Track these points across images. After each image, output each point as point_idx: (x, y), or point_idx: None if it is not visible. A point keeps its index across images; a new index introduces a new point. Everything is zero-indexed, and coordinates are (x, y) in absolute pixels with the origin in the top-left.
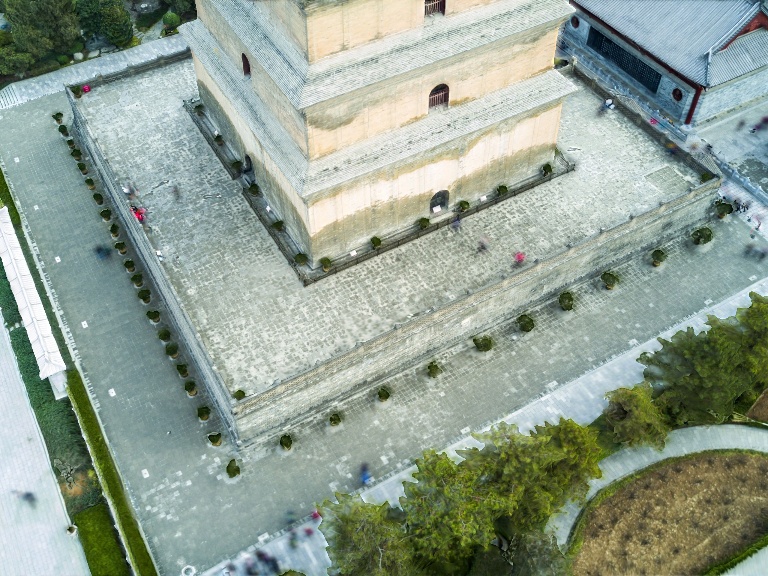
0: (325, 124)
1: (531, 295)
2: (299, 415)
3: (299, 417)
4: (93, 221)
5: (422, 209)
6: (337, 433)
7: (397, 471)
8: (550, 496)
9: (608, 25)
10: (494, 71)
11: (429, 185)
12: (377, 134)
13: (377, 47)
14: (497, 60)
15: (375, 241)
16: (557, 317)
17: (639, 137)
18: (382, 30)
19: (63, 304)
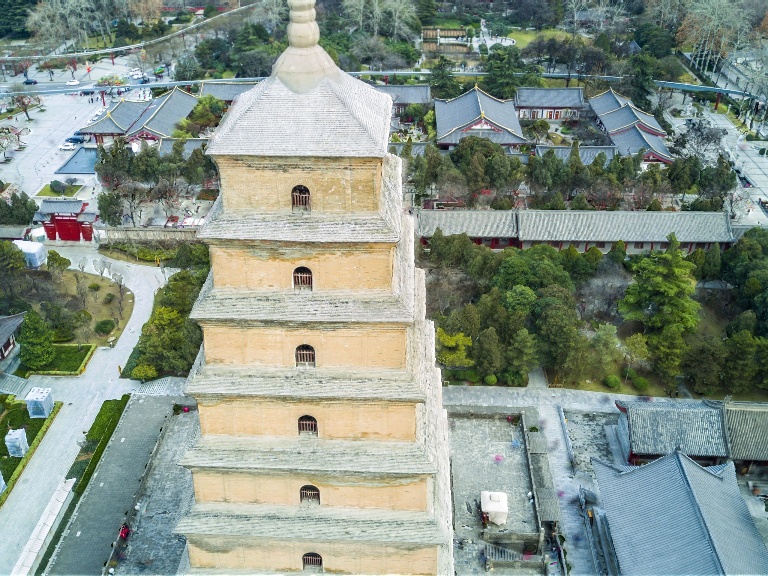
0: (204, 547)
1: None
2: None
3: None
4: (122, 514)
5: None
6: None
7: None
8: None
9: (612, 536)
10: (369, 559)
11: None
12: (254, 568)
13: (255, 508)
14: (371, 552)
15: None
16: None
17: None
18: (261, 498)
19: (52, 572)
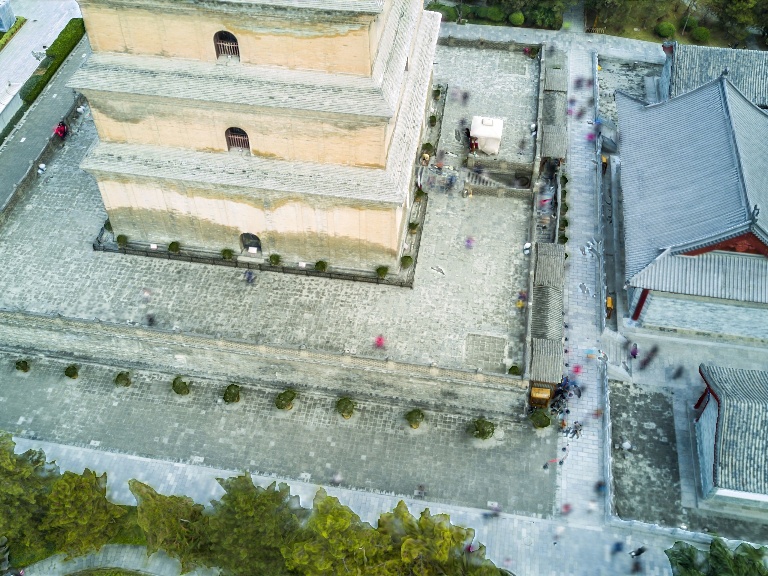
0: (110, 113)
1: (261, 373)
2: (7, 345)
3: (7, 347)
4: None
5: (230, 241)
6: (19, 377)
7: (17, 435)
8: (1, 522)
9: (621, 171)
10: (303, 140)
11: (234, 221)
12: (171, 146)
13: (163, 63)
14: (305, 130)
15: (171, 245)
16: (273, 408)
17: (515, 295)
18: (168, 49)
19: None
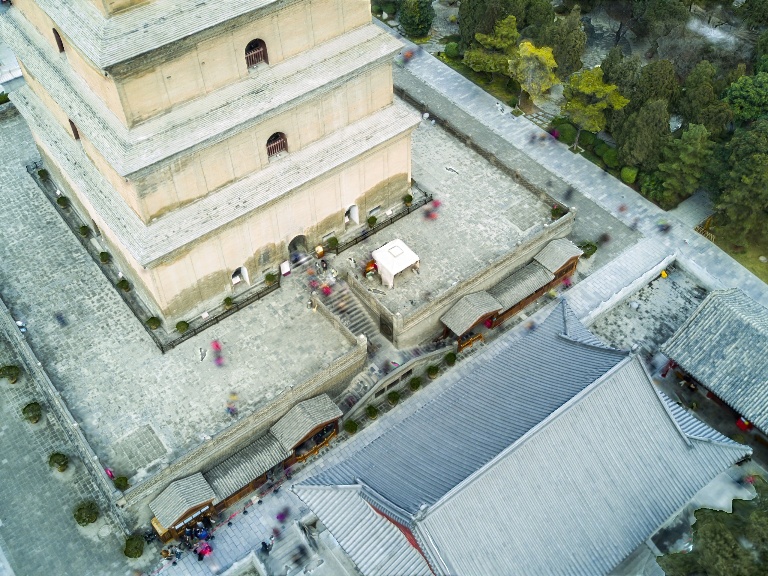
0: None
1: None
2: None
3: None
4: None
5: None
6: None
7: None
8: None
9: None
10: None
11: None
12: None
13: None
14: None
15: (60, 198)
16: None
17: (227, 422)
18: None
19: None
